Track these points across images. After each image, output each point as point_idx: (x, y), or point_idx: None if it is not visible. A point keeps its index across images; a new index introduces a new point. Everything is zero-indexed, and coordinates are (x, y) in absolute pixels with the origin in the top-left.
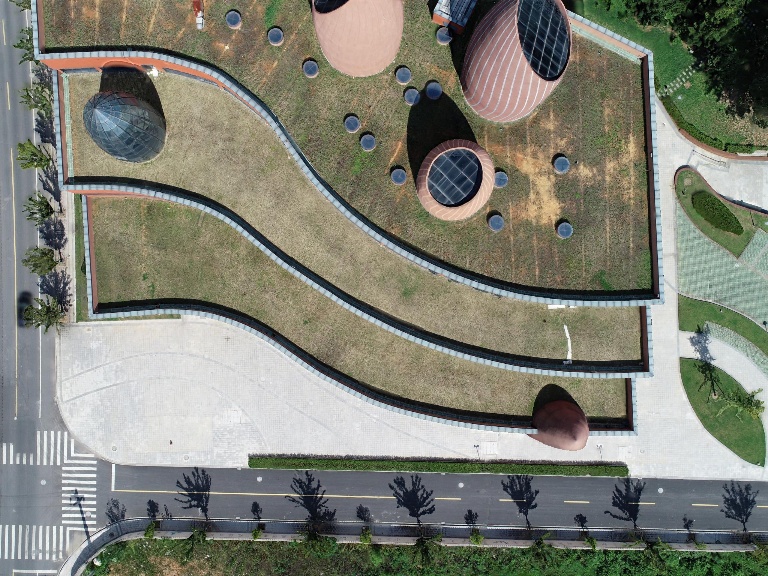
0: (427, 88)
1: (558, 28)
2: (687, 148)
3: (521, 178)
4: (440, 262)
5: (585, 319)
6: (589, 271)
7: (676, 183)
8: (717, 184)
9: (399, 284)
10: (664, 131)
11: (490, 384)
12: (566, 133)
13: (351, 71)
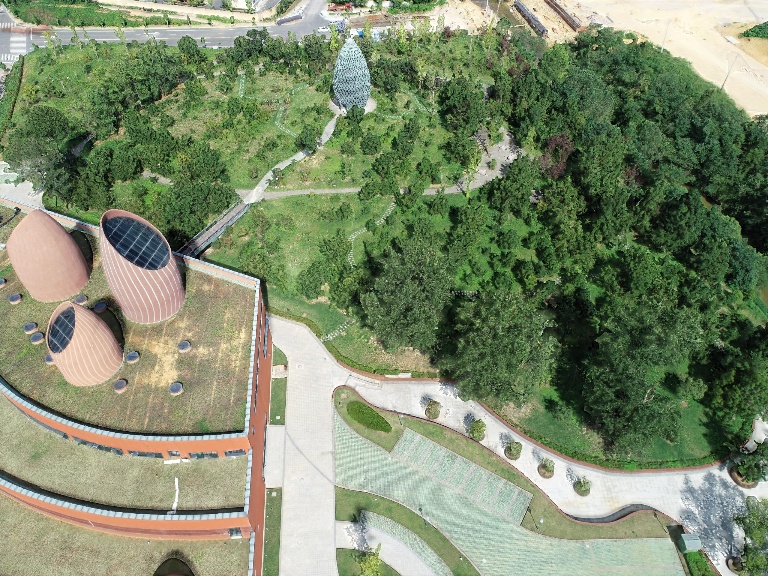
0: (95, 305)
1: (159, 246)
2: (345, 374)
3: (151, 357)
4: (63, 417)
5: (196, 472)
6: (192, 419)
7: (334, 397)
8: (372, 399)
9: (32, 449)
10: (325, 363)
11: (108, 561)
12: (194, 328)
13: (40, 295)
